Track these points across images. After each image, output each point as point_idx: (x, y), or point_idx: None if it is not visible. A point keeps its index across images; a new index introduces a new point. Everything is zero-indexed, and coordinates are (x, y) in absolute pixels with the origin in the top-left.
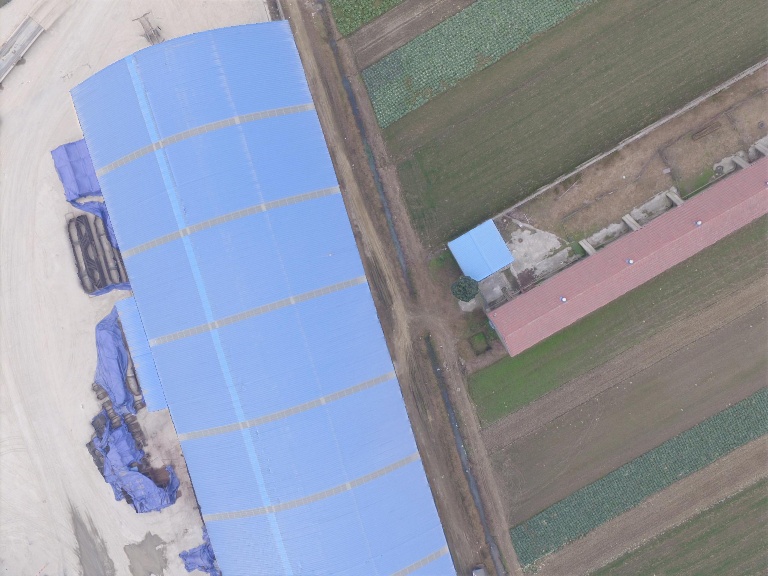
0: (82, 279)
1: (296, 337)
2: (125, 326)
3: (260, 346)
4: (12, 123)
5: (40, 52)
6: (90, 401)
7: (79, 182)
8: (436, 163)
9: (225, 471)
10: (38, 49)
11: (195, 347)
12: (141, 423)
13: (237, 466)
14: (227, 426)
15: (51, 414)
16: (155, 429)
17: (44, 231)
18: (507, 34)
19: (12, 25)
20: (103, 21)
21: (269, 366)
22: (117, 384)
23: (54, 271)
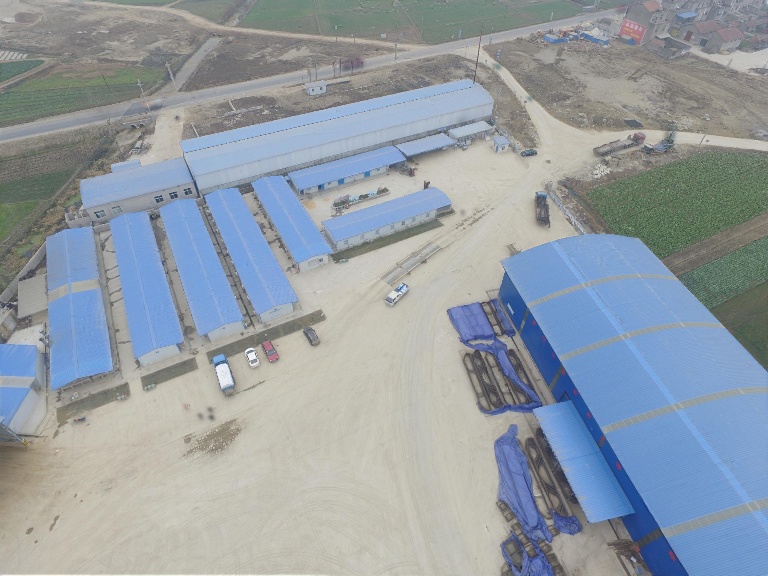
0: (479, 399)
1: (762, 421)
2: (546, 430)
3: (733, 425)
4: (416, 293)
5: (437, 258)
6: (495, 523)
7: (474, 328)
8: (757, 337)
9: (749, 569)
10: (436, 257)
11: (663, 427)
12: (558, 555)
13: (764, 560)
14: (731, 508)
15: (451, 536)
16: (576, 564)
17: (441, 361)
18: (762, 269)
19: (418, 245)
20: (479, 247)
21: (751, 444)
22: (527, 502)
23: (451, 392)
